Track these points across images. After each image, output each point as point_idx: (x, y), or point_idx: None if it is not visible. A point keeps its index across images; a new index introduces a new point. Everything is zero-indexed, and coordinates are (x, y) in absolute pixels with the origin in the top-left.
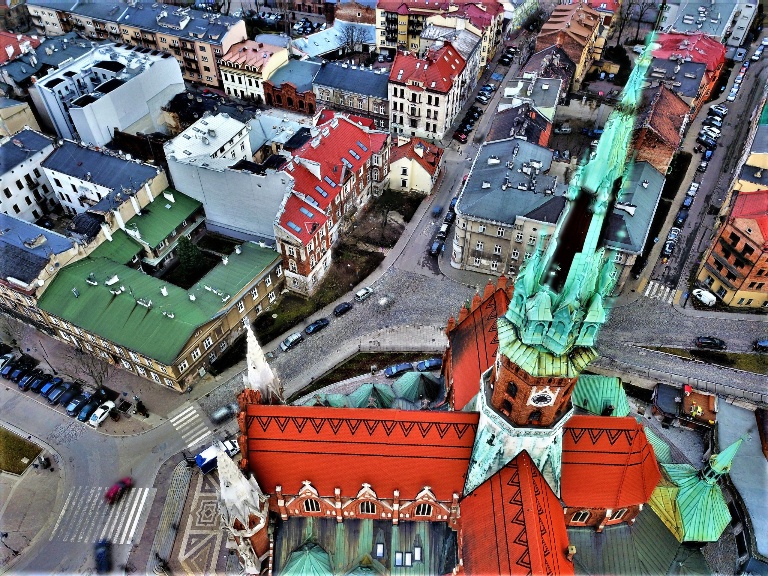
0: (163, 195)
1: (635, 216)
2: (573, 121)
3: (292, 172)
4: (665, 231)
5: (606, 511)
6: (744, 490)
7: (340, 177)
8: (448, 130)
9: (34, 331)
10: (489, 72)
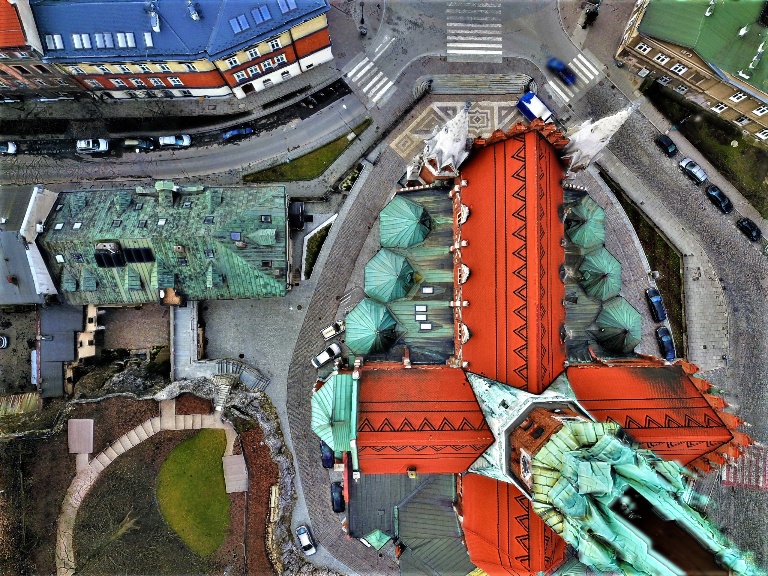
0: None
1: None
2: None
3: None
4: None
5: None
6: None
7: None
8: None
9: None
10: None
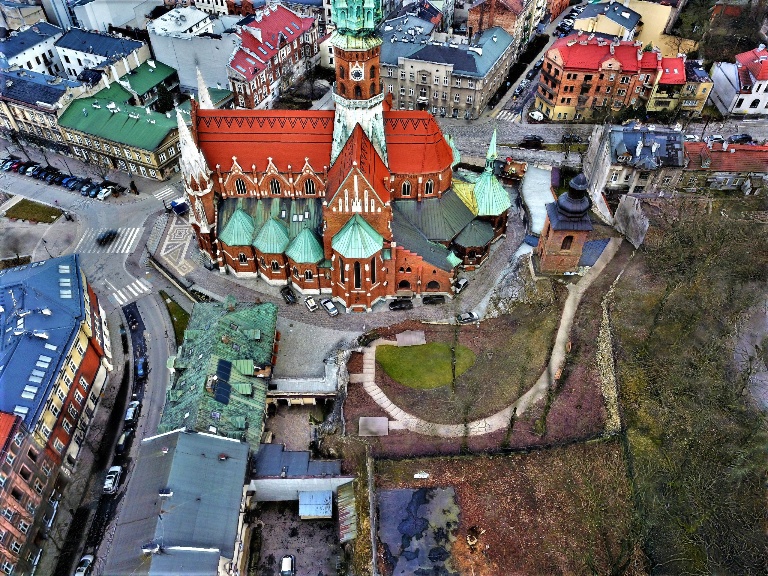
0: (147, 63)
1: (483, 57)
2: None
3: (240, 35)
4: (519, 82)
5: (418, 179)
6: (532, 206)
7: (277, 43)
8: None
9: (54, 154)
10: None
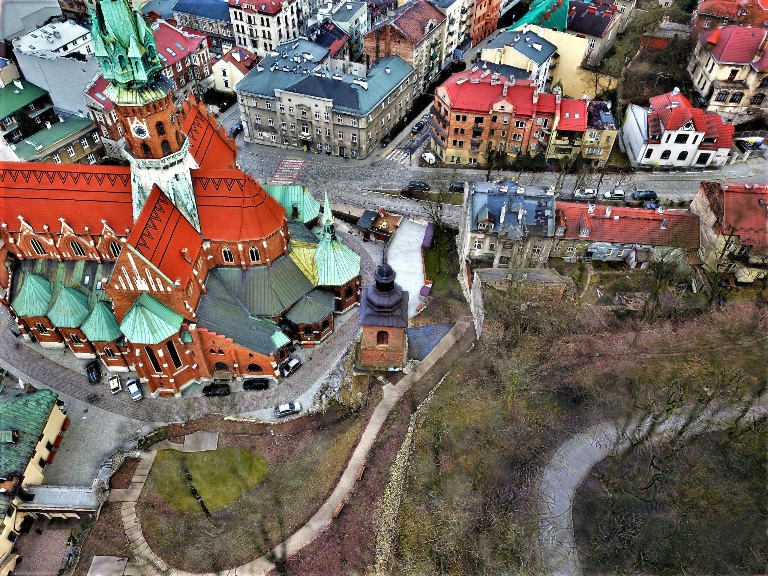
0: (14, 83)
1: (370, 91)
2: None
3: None
4: (421, 116)
5: (238, 246)
6: (395, 270)
7: None
8: None
9: None
10: None
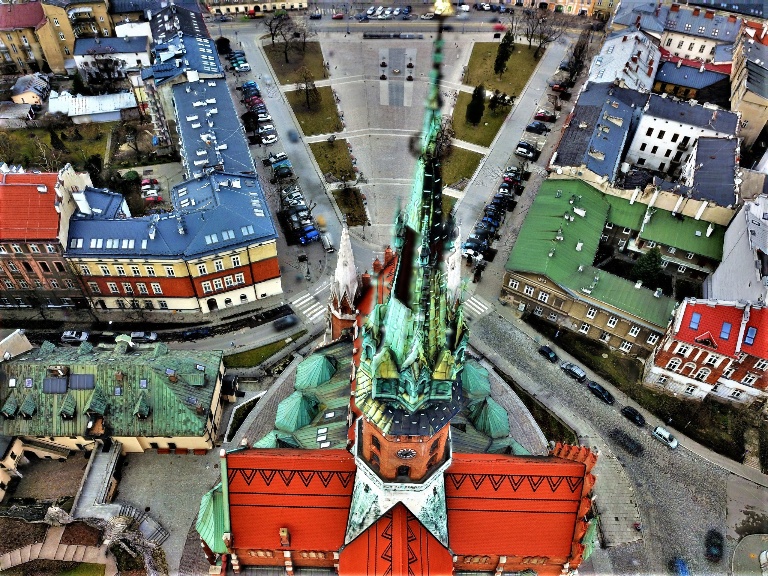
0: None
1: None
2: None
3: None
4: None
5: None
6: None
7: None
8: None
9: None
10: None
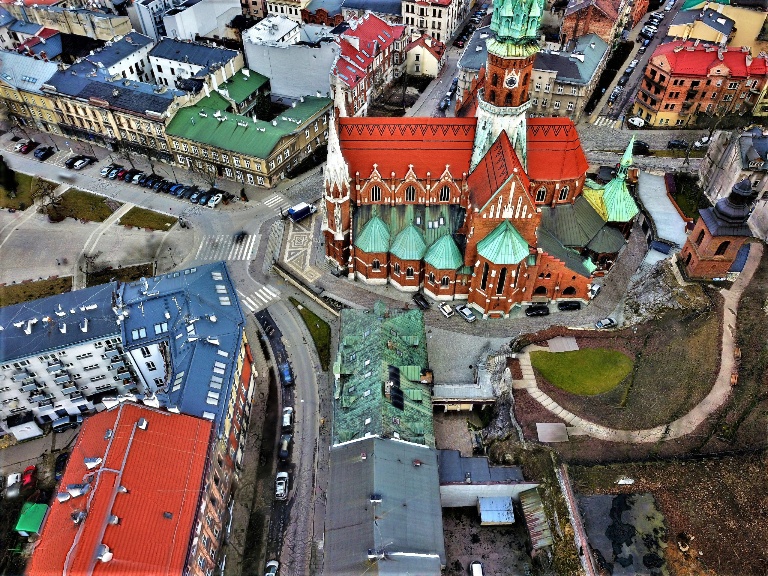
0: (241, 71)
1: (585, 63)
2: (546, 29)
3: (339, 44)
4: (611, 88)
5: (555, 185)
6: (652, 212)
7: (373, 51)
8: (449, 40)
9: (155, 162)
10: (480, 3)
